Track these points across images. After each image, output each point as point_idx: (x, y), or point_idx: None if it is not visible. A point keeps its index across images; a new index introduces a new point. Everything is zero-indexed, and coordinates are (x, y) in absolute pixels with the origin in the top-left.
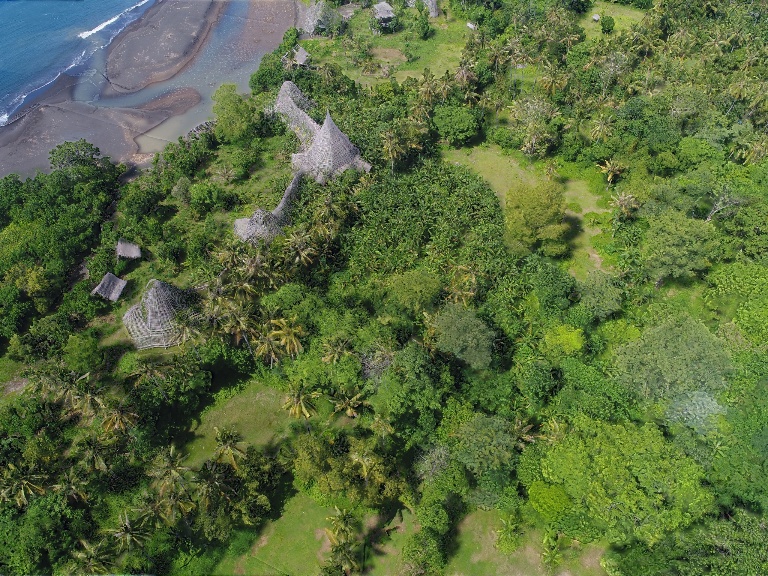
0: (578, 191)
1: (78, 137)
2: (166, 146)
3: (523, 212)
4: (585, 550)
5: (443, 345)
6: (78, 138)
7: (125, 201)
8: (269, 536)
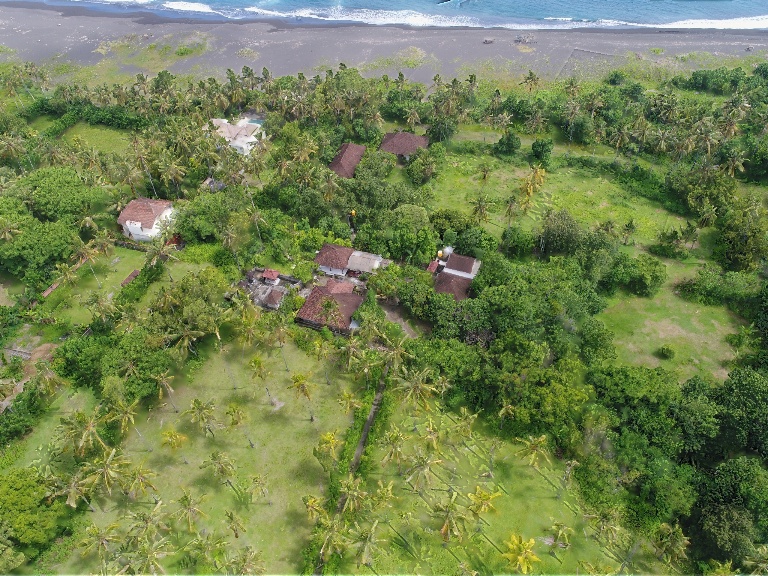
0: None
1: None
2: None
3: None
4: None
5: None
6: None
7: None
8: (684, 220)
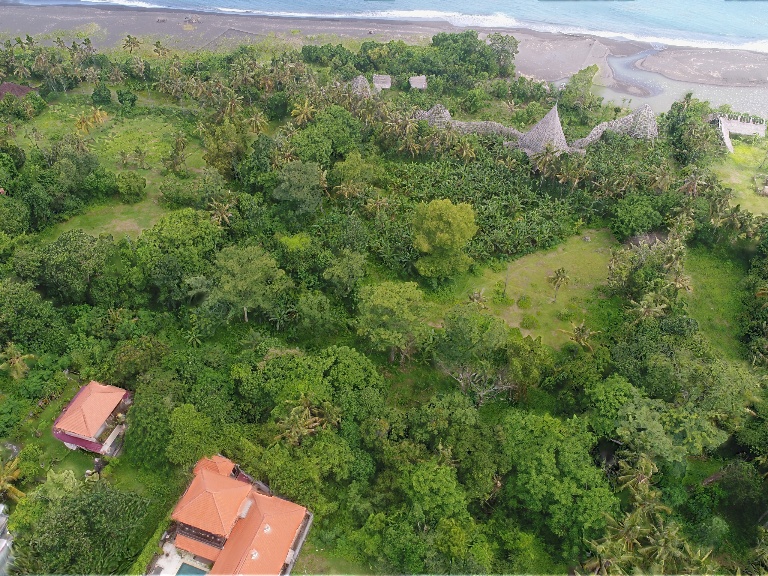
0: None
1: (557, 57)
2: None
3: None
4: None
5: None
6: (555, 57)
7: None
8: None
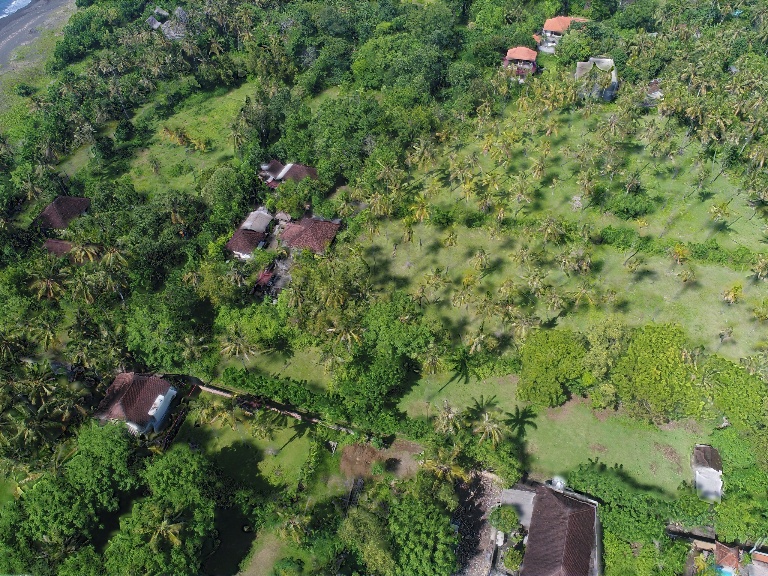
0: None
1: None
2: None
3: None
4: (378, 94)
5: (321, 20)
6: None
7: None
8: (234, 92)
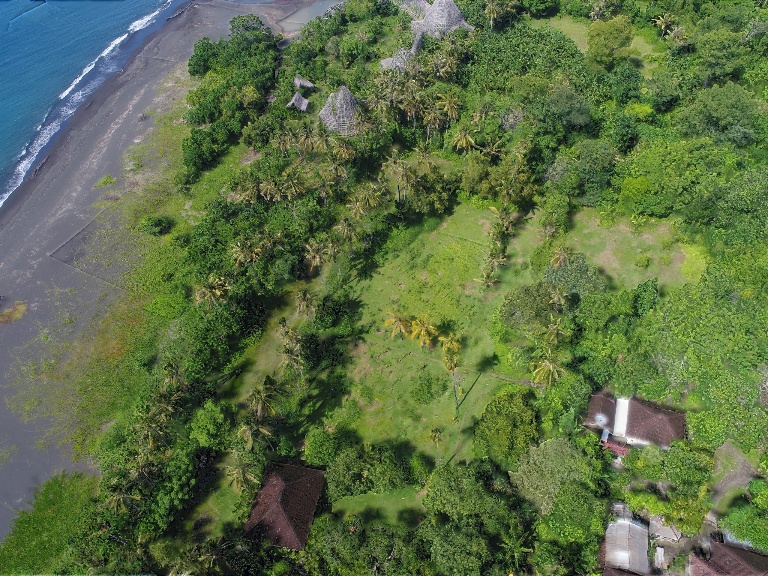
0: (637, 43)
1: None
2: (309, 22)
3: (603, 37)
4: (659, 224)
5: (556, 108)
6: None
7: (294, 52)
8: (448, 223)
